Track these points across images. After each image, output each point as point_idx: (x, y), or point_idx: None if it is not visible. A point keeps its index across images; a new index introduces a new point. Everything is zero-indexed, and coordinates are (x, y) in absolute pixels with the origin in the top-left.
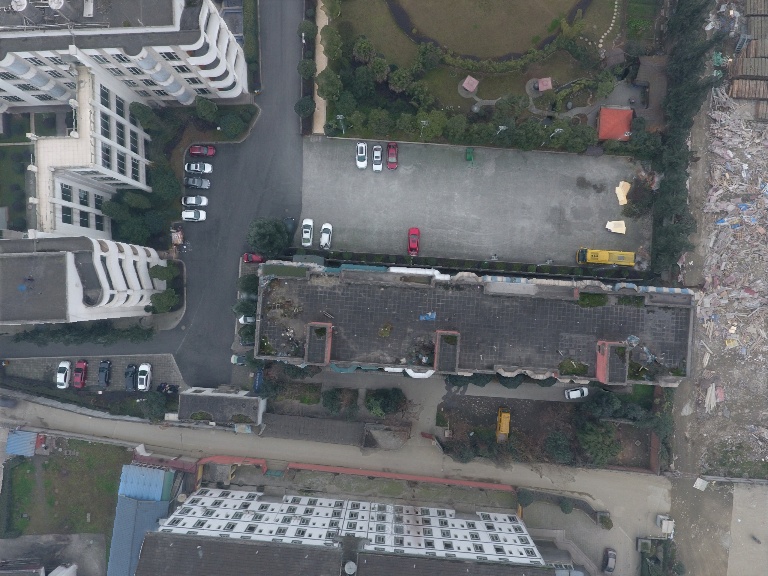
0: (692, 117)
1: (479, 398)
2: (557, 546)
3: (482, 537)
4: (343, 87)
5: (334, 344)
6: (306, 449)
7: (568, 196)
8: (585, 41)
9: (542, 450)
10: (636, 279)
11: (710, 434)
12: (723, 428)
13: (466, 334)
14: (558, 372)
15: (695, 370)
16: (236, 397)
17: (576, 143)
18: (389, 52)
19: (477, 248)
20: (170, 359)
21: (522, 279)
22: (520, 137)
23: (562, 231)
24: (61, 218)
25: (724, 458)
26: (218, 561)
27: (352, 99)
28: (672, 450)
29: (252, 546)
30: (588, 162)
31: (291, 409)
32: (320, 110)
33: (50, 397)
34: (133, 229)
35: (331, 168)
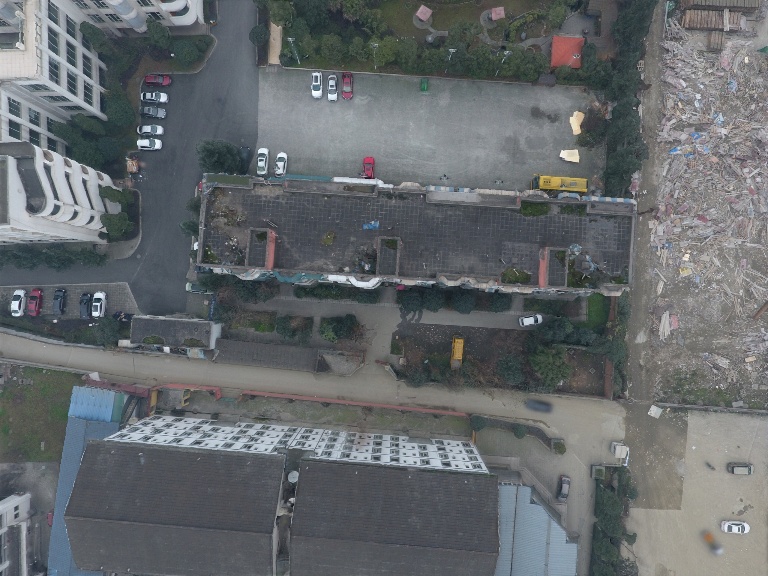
0: (645, 48)
1: (434, 326)
2: None
3: (431, 455)
4: None
5: (278, 253)
6: (261, 377)
7: (522, 126)
8: None
9: (494, 373)
10: None
11: (664, 362)
12: (677, 356)
13: (409, 243)
14: (500, 279)
15: (649, 298)
16: (188, 321)
17: (528, 69)
18: None
19: (432, 177)
20: (125, 288)
21: (465, 189)
22: (471, 62)
23: (517, 161)
24: (8, 131)
25: (678, 386)
26: (159, 467)
27: (305, 26)
28: (626, 377)
29: (194, 453)
30: (542, 92)
31: (246, 337)
32: (276, 41)
33: (5, 326)
34: (85, 152)
35: (287, 98)
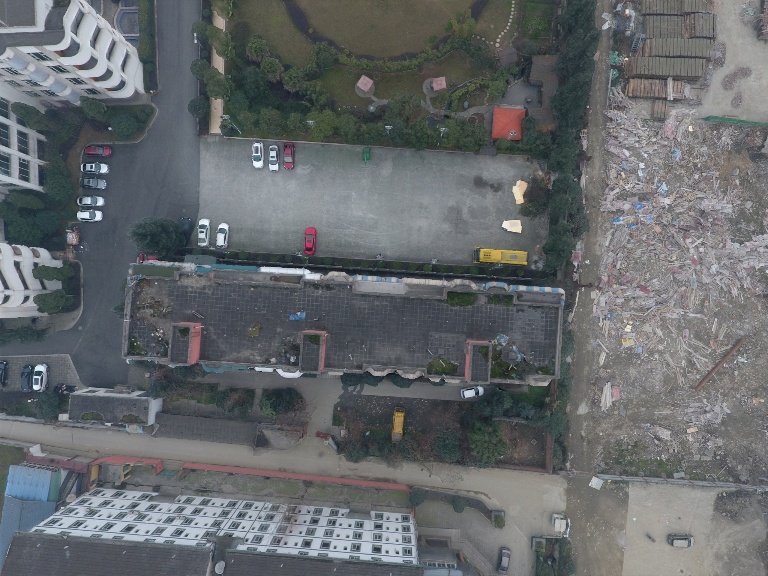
0: (589, 116)
1: (375, 397)
2: (450, 545)
3: (364, 536)
4: (239, 87)
5: (204, 344)
6: (202, 449)
7: (465, 195)
8: (482, 40)
9: (432, 449)
10: (530, 278)
11: (606, 433)
12: (619, 427)
13: (336, 334)
14: (425, 371)
15: (591, 369)
16: (126, 397)
17: (467, 142)
18: (286, 52)
19: (374, 248)
20: (67, 359)
21: (393, 278)
22: (410, 136)
23: (459, 230)
24: None
25: (620, 457)
26: (85, 561)
27: (243, 99)
28: (568, 449)
29: (120, 546)
30: (485, 161)
31: (188, 409)
32: (217, 110)
33: None
34: (21, 229)
35: (228, 168)
